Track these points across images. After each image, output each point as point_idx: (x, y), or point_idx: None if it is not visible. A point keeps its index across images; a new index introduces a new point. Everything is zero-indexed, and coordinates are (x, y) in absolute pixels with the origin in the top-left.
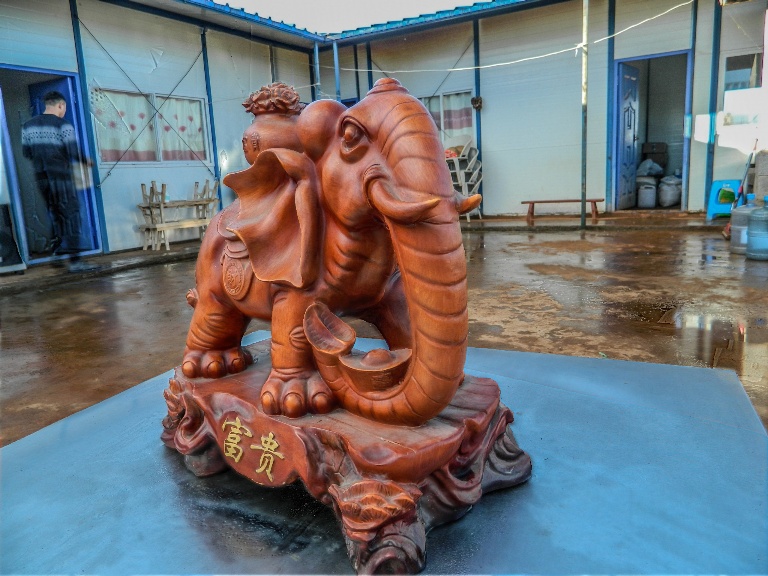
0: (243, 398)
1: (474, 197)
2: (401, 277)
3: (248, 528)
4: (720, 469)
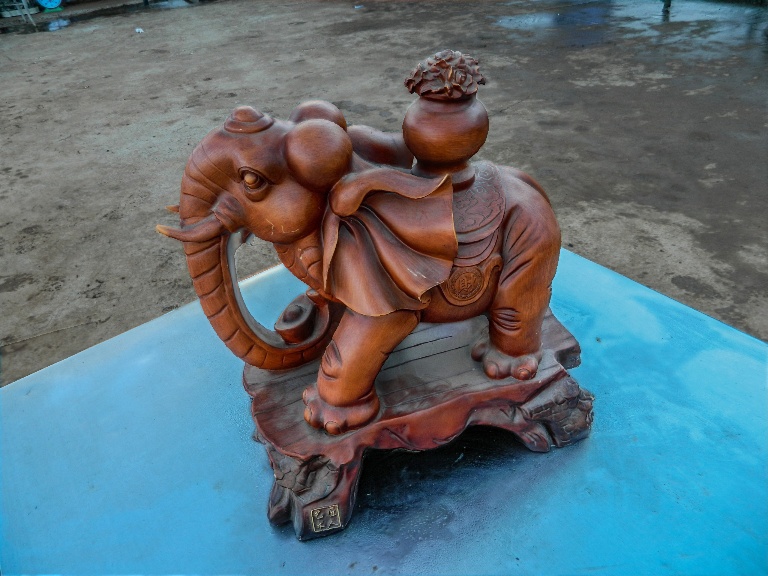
0: None
1: None
2: (348, 312)
3: None
4: None
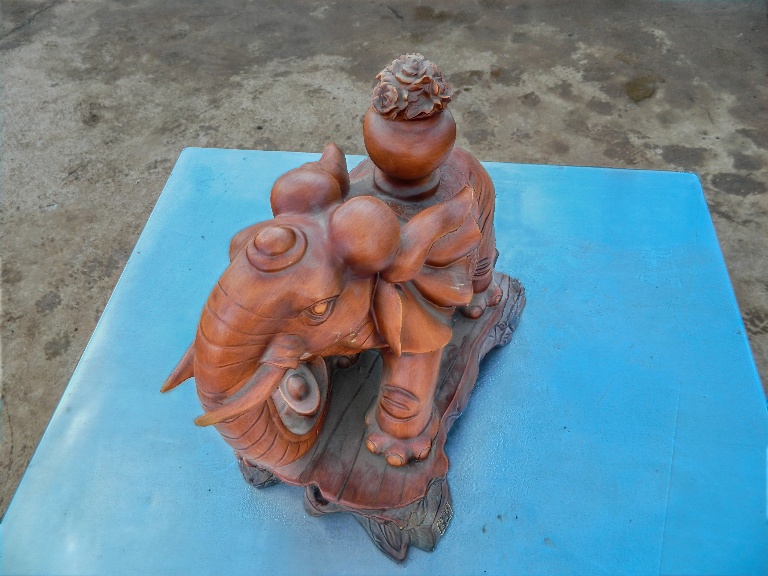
0: None
1: None
2: (402, 355)
3: None
4: None
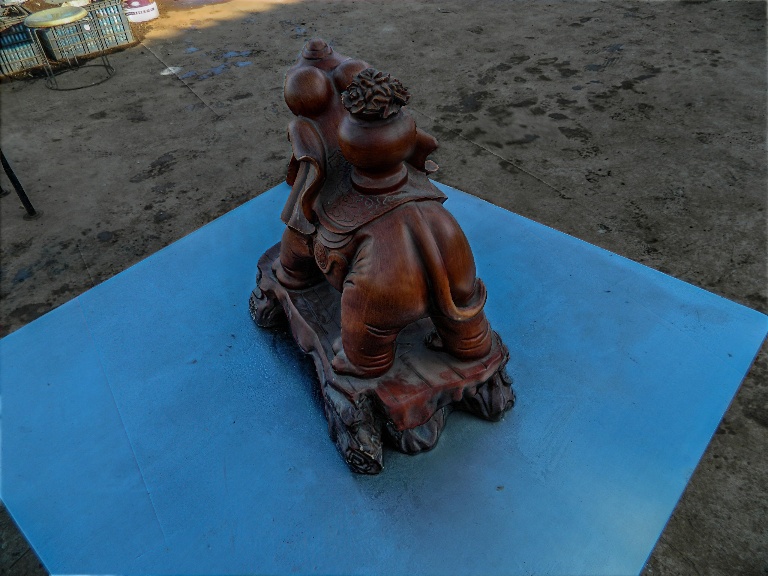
0: None
1: None
2: None
3: None
4: (155, 276)
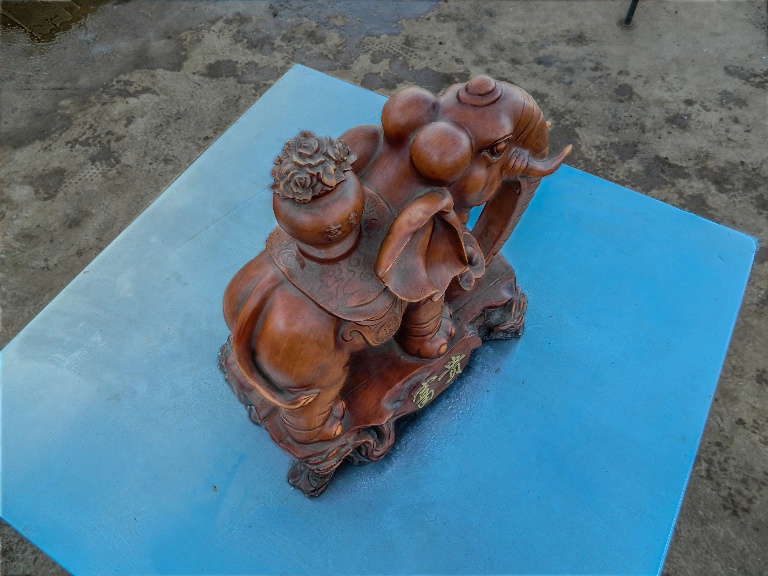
0: (403, 377)
1: (548, 124)
2: None
3: (463, 402)
4: None
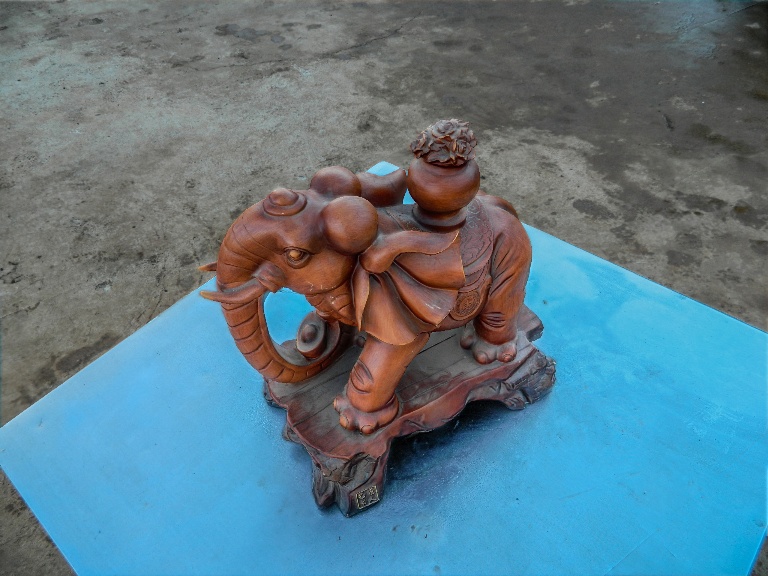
0: None
1: None
2: (374, 339)
3: None
4: None
